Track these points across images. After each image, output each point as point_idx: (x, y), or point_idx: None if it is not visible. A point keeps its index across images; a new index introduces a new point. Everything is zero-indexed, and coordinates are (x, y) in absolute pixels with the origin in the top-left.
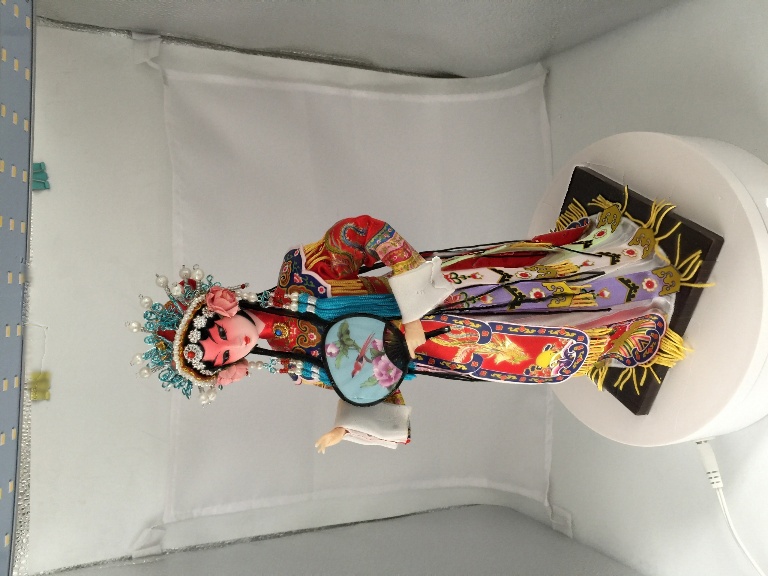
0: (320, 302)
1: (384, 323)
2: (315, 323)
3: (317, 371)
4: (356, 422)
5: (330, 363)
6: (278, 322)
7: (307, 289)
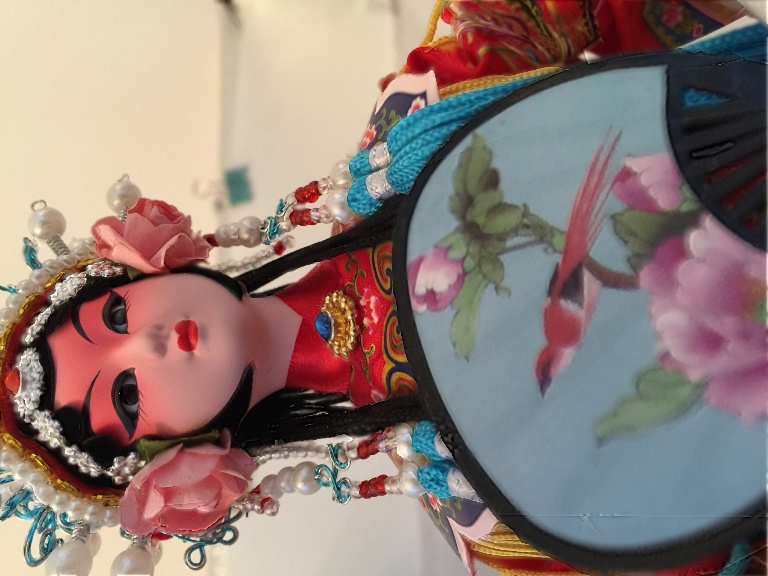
0: None
1: (659, 68)
2: None
3: None
4: None
5: (430, 341)
6: (326, 294)
7: None
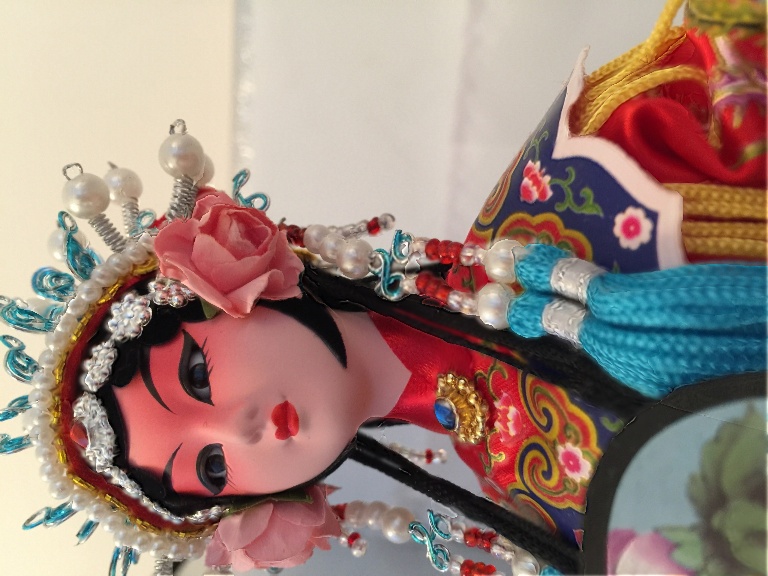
0: (609, 286)
1: None
2: (585, 398)
3: None
4: None
5: None
6: (449, 370)
7: (566, 228)
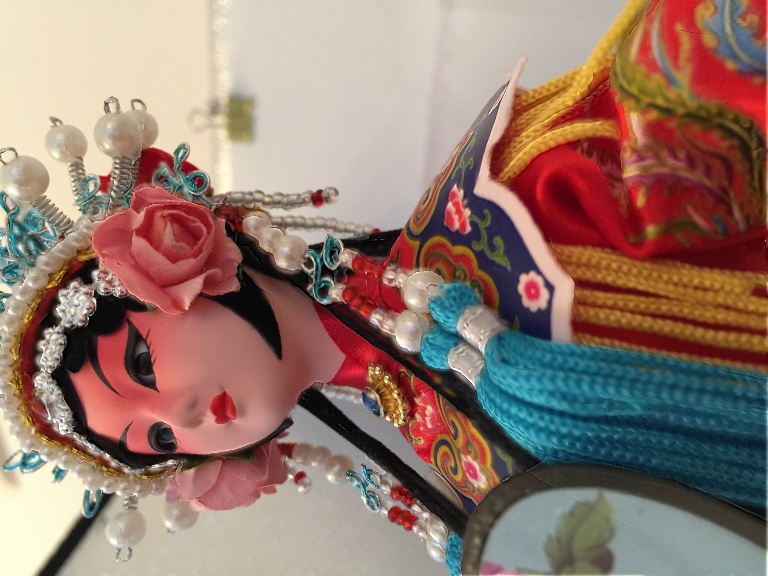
0: (503, 351)
1: None
2: (482, 429)
3: None
4: None
5: None
6: (377, 364)
7: (479, 269)
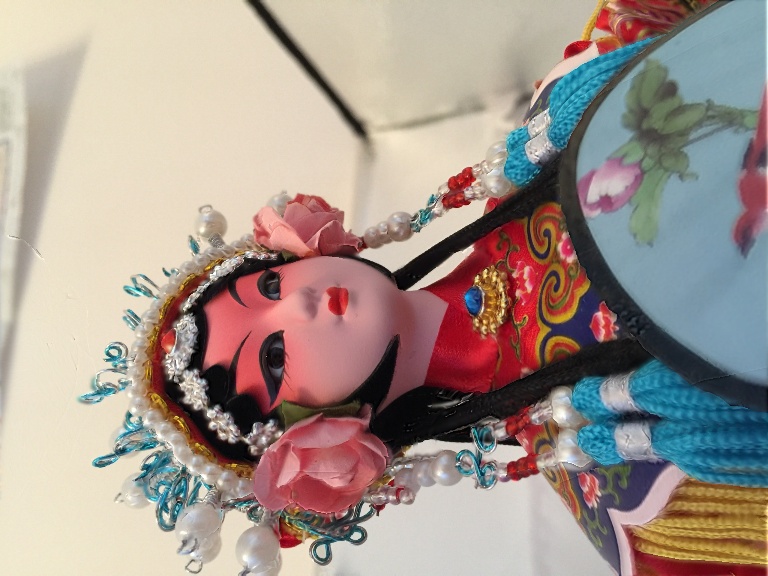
0: None
1: None
2: None
3: (622, 392)
4: None
5: (607, 239)
6: (476, 274)
7: None
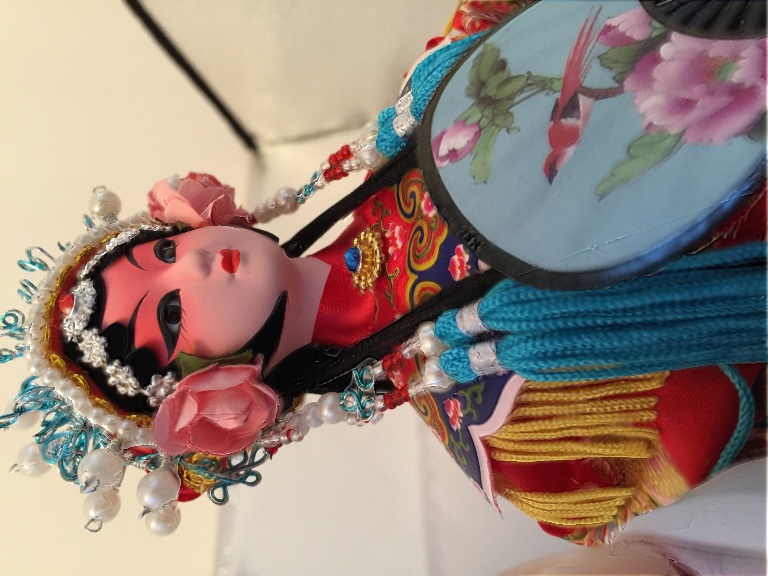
0: None
1: None
2: None
3: (473, 315)
4: (720, 504)
5: (453, 182)
6: None
7: None
